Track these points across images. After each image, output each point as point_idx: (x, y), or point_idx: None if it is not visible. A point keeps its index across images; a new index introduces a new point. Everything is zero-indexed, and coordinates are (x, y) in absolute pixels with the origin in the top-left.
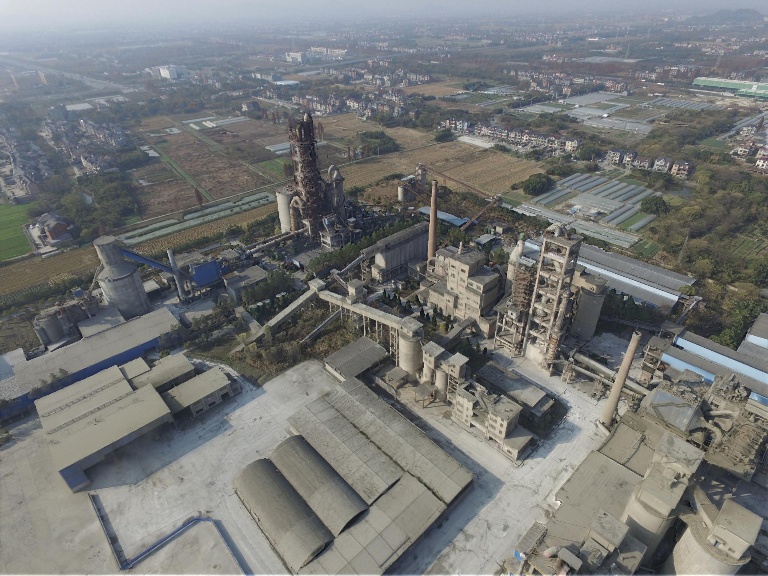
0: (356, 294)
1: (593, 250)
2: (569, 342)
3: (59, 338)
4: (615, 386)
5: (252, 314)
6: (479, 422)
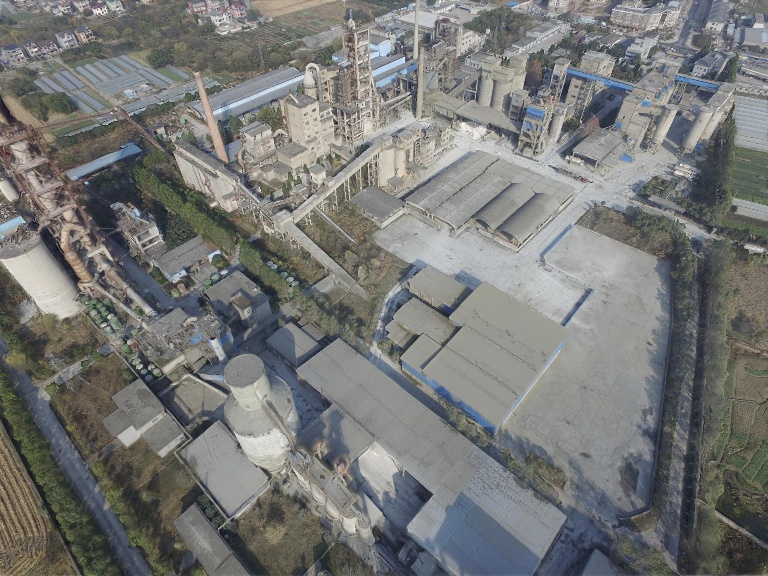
0: (325, 176)
1: (233, 90)
2: None
3: None
4: None
5: None
6: None
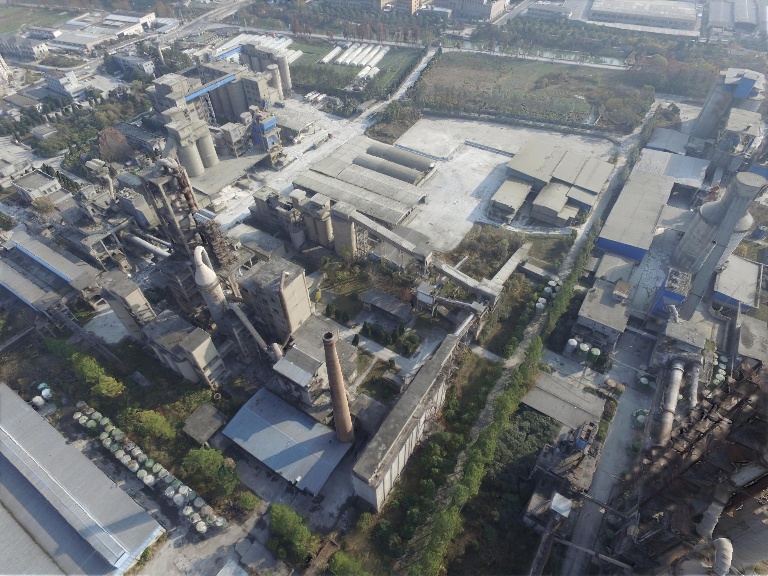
0: None
1: None
2: None
3: None
4: None
5: None
6: None
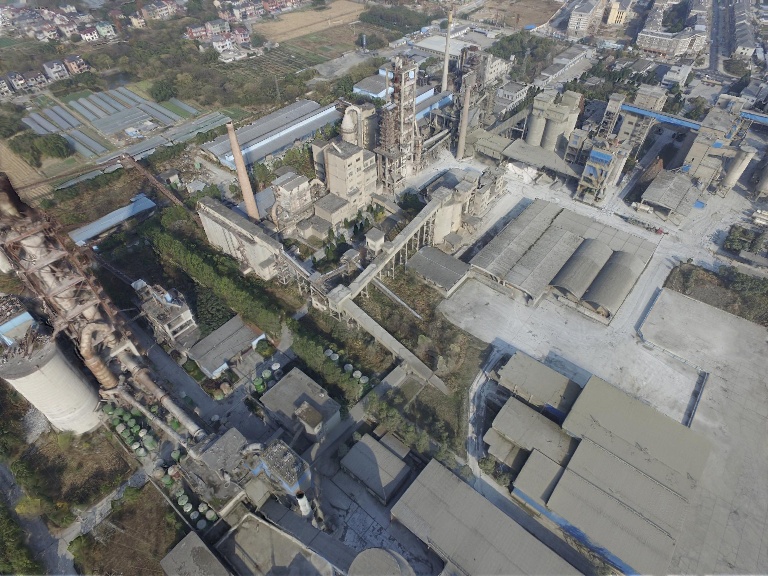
0: None
1: (250, 128)
2: None
3: None
4: (465, 128)
5: (368, 390)
6: None
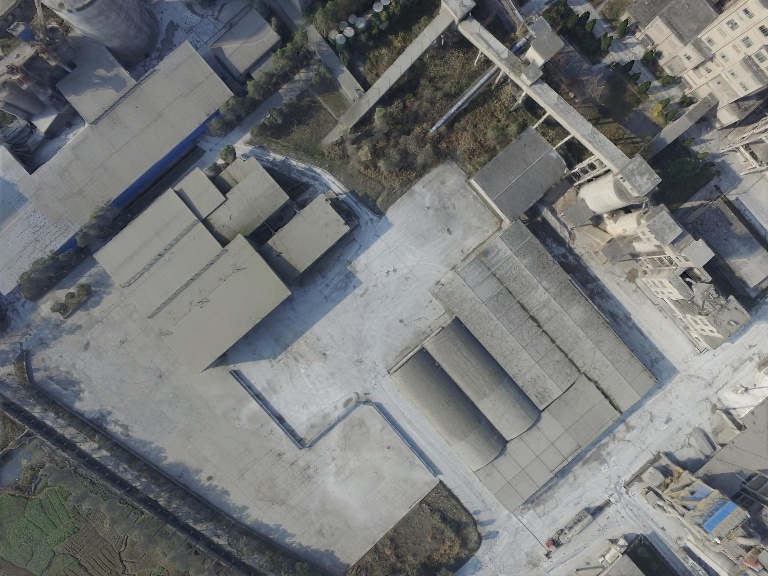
0: (542, 64)
1: None
2: None
3: (41, 108)
4: None
5: (336, 50)
6: (678, 307)
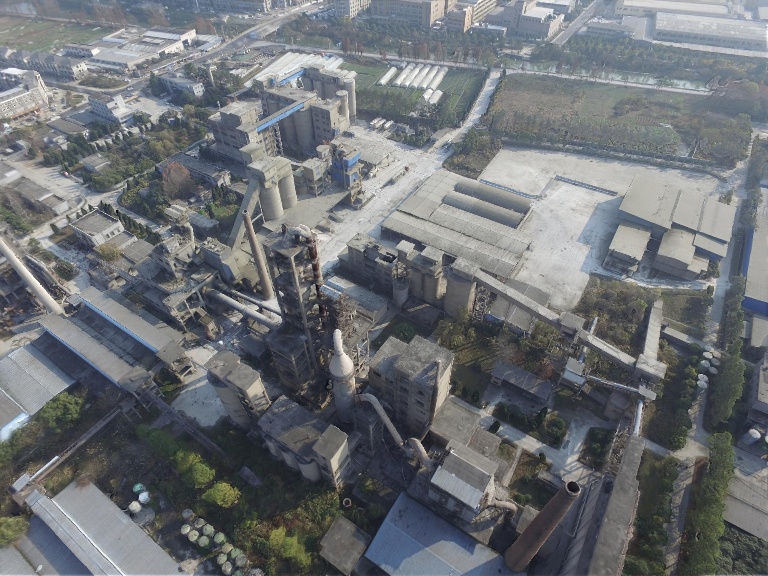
0: None
1: None
2: (270, 394)
3: None
4: None
5: None
6: None
